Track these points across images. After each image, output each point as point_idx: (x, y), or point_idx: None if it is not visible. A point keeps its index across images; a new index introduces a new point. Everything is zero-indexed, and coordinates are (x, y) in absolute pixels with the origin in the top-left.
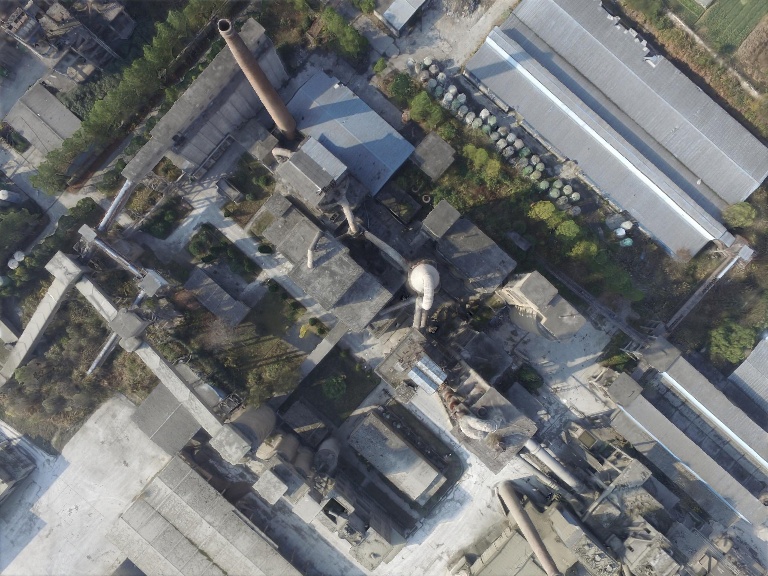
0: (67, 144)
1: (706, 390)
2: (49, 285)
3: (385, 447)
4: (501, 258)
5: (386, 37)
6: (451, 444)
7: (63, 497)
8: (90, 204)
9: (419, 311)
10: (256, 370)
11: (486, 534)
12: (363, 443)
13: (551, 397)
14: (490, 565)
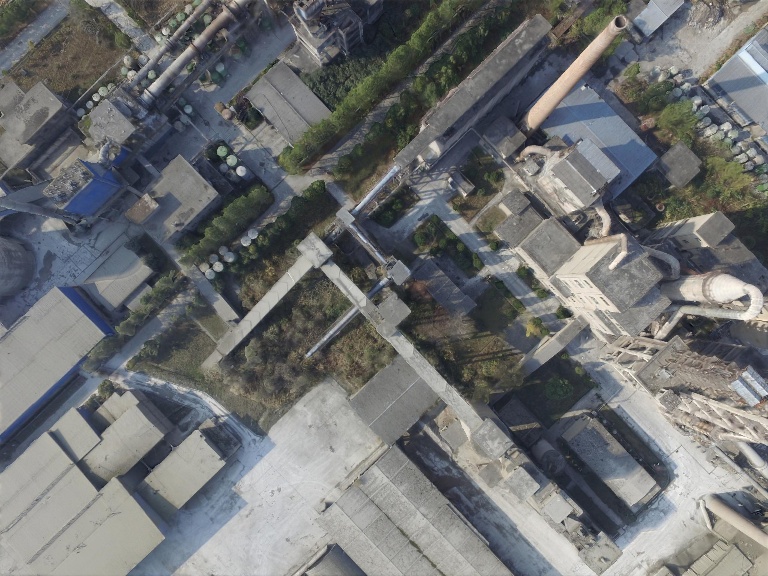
0: (325, 125)
1: None
2: (272, 265)
3: (606, 452)
4: (761, 273)
5: (626, 42)
6: (660, 453)
7: (266, 478)
8: (322, 187)
9: None
10: (471, 365)
11: (687, 546)
12: (584, 446)
13: None
14: None
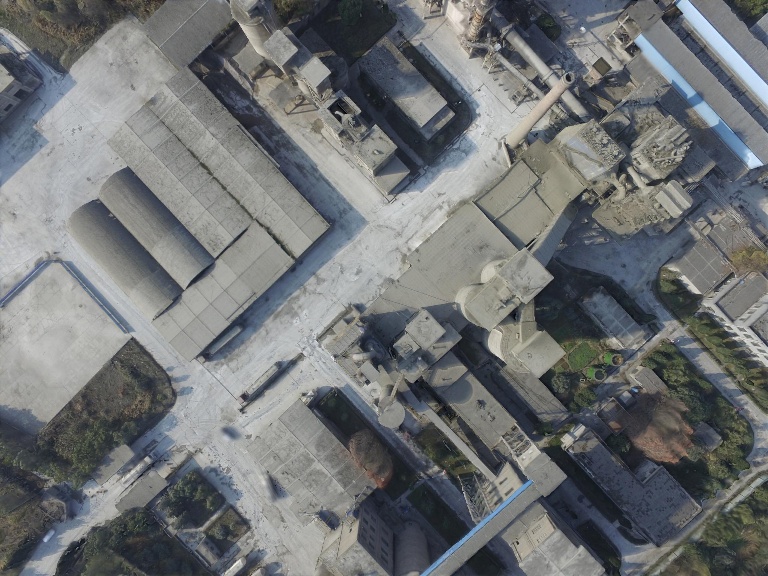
0: None
1: (728, 19)
2: None
3: (396, 70)
4: None
5: None
6: (462, 92)
7: (67, 116)
8: None
9: None
10: None
11: None
12: (374, 65)
13: (567, 52)
14: (492, 192)
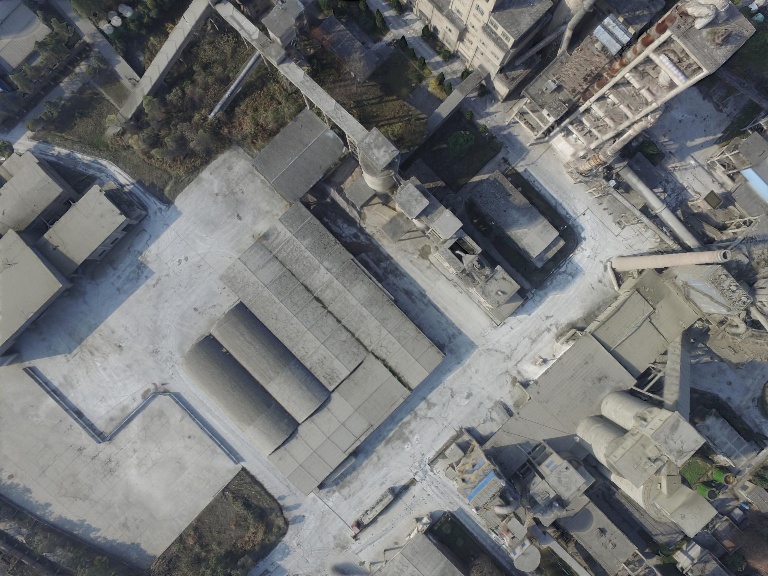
0: None
1: None
2: None
3: (509, 203)
4: None
5: None
6: (567, 217)
7: (173, 247)
8: None
9: (567, 41)
10: None
11: (596, 308)
12: (487, 198)
13: (669, 176)
14: (608, 322)
